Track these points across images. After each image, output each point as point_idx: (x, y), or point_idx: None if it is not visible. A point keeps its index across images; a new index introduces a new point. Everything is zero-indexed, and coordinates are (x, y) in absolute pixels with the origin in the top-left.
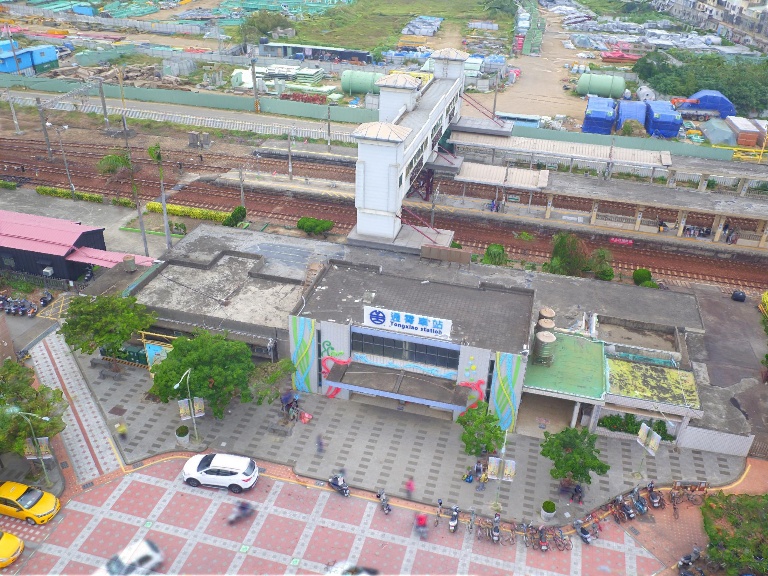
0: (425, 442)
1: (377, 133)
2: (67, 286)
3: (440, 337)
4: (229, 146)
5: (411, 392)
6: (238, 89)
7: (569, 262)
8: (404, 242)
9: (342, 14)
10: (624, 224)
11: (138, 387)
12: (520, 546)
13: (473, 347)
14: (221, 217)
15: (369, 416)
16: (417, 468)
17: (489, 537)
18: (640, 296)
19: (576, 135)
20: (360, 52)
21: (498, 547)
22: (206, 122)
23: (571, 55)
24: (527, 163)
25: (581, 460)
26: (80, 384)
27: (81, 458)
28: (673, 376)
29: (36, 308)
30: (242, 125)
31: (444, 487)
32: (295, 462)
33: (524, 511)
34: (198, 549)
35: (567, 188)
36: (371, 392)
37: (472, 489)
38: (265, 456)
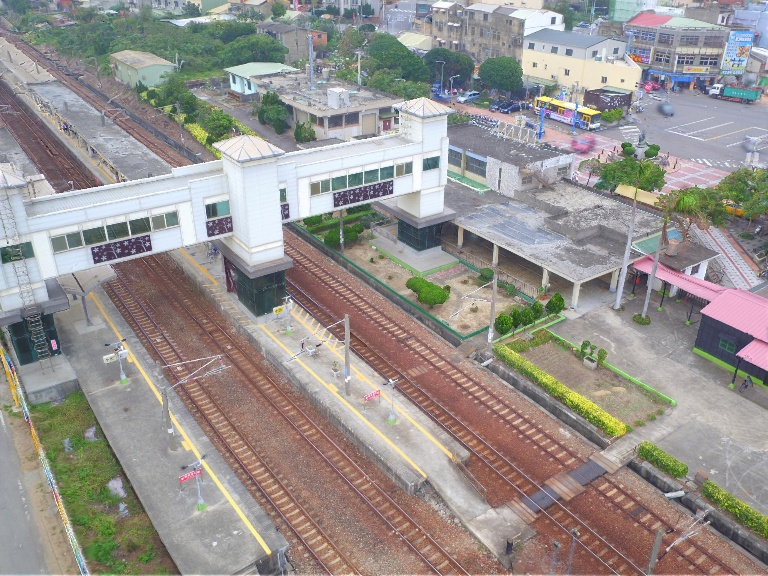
0: None
1: None
2: None
3: (501, 135)
4: None
5: None
6: None
7: None
8: None
9: None
10: None
11: None
12: None
13: None
14: None
15: None
16: None
17: None
18: None
19: None
20: None
21: None
22: None
23: None
24: None
25: None
26: None
27: None
28: None
29: None
30: None
31: None
32: None
33: None
34: None
35: None
36: None
37: None
38: None
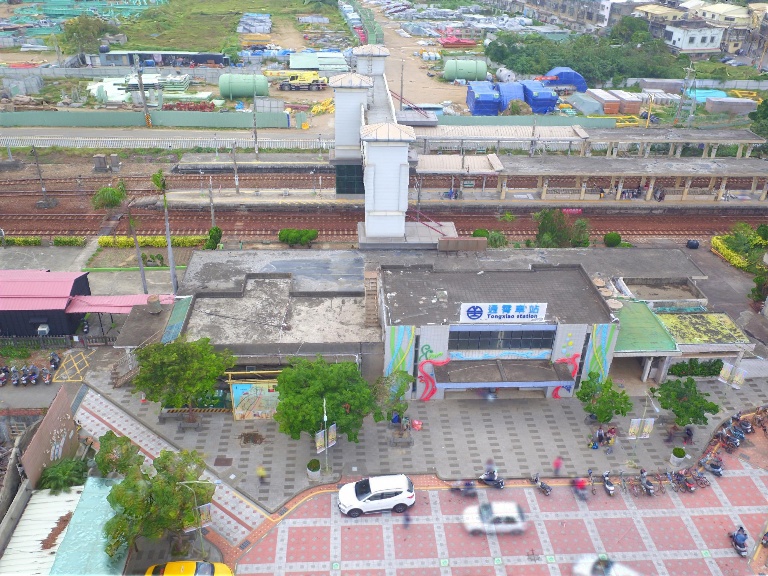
0: (536, 422)
1: (388, 134)
2: (70, 342)
3: (534, 321)
4: (141, 166)
5: (518, 378)
6: (110, 104)
7: (560, 236)
8: (416, 239)
9: (163, 15)
10: (571, 195)
11: (227, 433)
12: (671, 493)
13: (572, 324)
14: (190, 242)
15: (472, 410)
16: (545, 447)
17: (643, 492)
18: (639, 256)
19: (480, 119)
20: (215, 54)
21: (655, 499)
22: (102, 143)
23: (412, 43)
24: (448, 150)
25: (700, 405)
26: (160, 444)
27: (217, 519)
28: (713, 319)
29: (49, 373)
30: (146, 142)
31: (579, 458)
32: (435, 469)
33: (655, 462)
34: (401, 575)
35: (520, 168)
36: (483, 386)
37: (602, 454)
38: (403, 470)
